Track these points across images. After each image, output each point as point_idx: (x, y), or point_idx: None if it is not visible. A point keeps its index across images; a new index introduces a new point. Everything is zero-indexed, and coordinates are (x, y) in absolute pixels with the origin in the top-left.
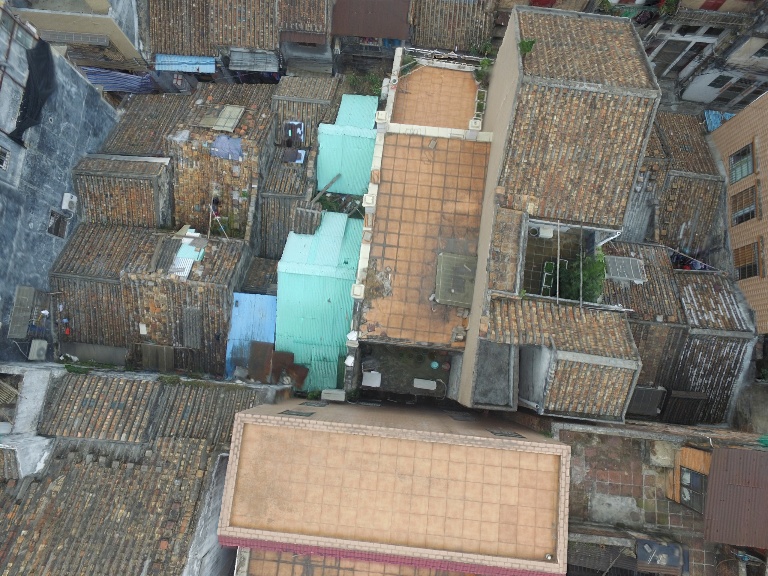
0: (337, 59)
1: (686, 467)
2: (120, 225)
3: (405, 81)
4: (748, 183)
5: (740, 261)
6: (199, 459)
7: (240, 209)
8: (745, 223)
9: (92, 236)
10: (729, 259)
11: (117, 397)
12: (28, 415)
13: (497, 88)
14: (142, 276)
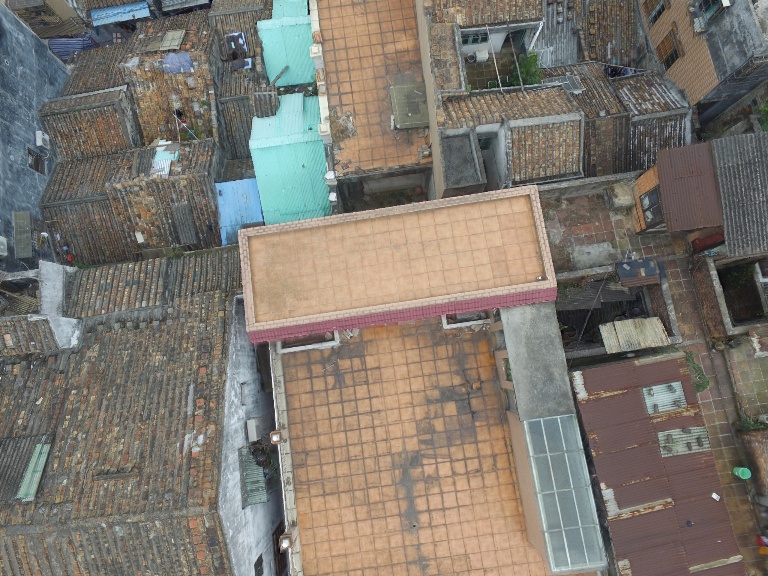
0: None
1: (643, 193)
2: (95, 157)
3: None
4: None
5: (663, 55)
6: (217, 304)
7: (203, 120)
8: (659, 19)
9: (71, 170)
10: (654, 59)
11: (130, 276)
12: (52, 301)
13: None
14: (126, 183)
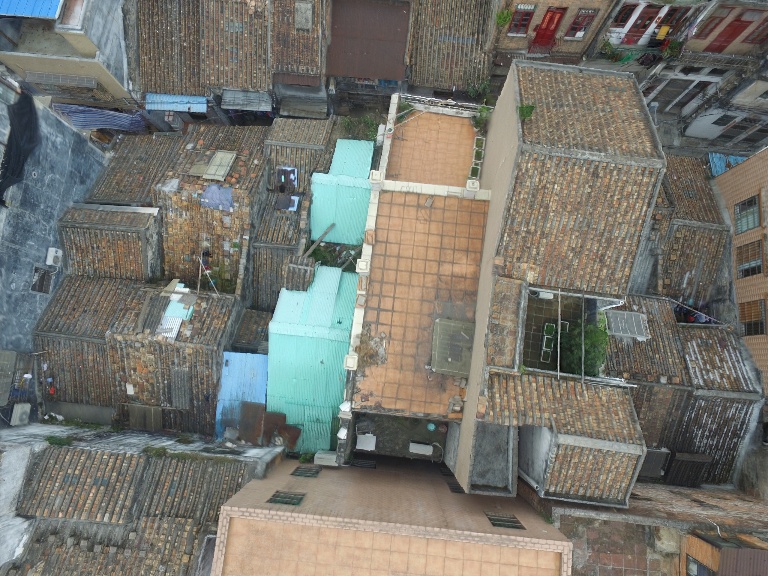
0: (332, 96)
1: (693, 557)
2: (107, 277)
3: (401, 129)
4: (754, 236)
5: (746, 316)
6: (185, 542)
7: (231, 259)
8: (751, 277)
9: (78, 290)
10: (734, 312)
11: (100, 472)
12: (6, 496)
13: (496, 142)
14: (128, 337)
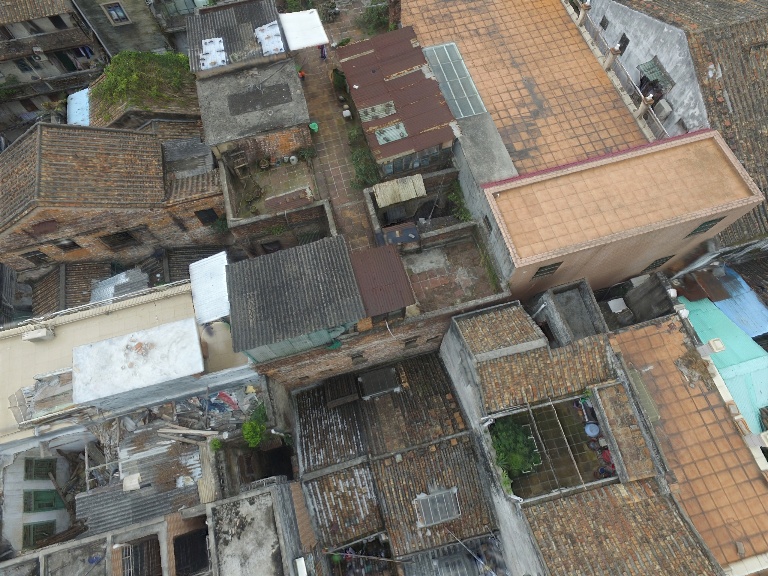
0: None
1: None
2: None
3: None
4: None
5: None
6: None
7: None
8: None
9: None
10: None
11: None
12: None
13: None
14: None
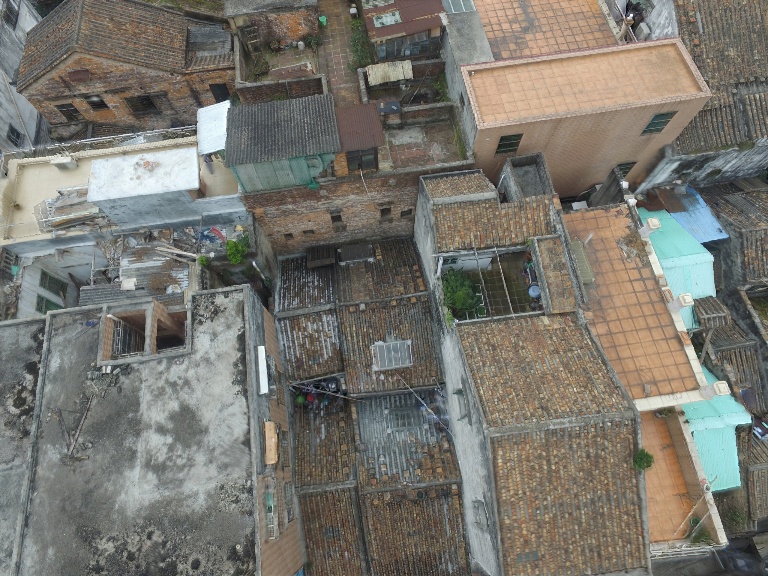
0: None
1: None
2: None
3: None
4: None
5: None
6: None
7: (764, 325)
8: None
9: None
10: None
11: None
12: None
13: None
14: None
